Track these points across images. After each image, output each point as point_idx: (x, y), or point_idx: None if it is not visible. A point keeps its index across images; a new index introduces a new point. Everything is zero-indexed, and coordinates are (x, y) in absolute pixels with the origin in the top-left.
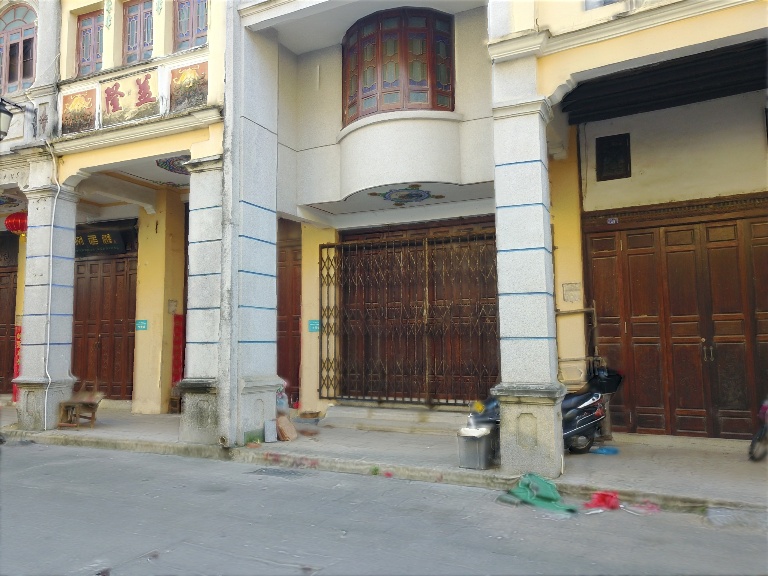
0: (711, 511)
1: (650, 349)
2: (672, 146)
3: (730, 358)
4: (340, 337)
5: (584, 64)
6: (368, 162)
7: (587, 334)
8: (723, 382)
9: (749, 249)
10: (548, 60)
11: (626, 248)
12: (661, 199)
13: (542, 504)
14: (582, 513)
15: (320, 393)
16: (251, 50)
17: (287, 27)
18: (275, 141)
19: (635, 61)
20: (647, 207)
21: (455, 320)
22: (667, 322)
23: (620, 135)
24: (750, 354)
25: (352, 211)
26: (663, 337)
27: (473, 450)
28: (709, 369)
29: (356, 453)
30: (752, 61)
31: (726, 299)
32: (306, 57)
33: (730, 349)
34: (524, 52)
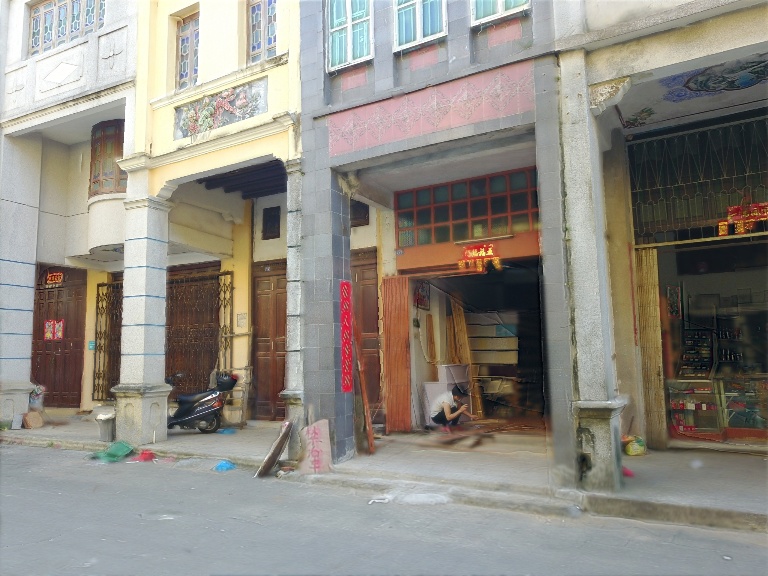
0: (190, 459)
1: None
2: None
3: None
4: (108, 354)
5: (171, 176)
6: (95, 229)
7: (249, 350)
8: None
9: None
10: (156, 171)
11: (276, 288)
12: None
13: (107, 459)
14: (120, 462)
15: (93, 396)
16: (11, 150)
17: (47, 130)
18: (36, 213)
19: (195, 175)
20: None
21: (175, 341)
22: None
23: (275, 207)
24: None
25: (110, 260)
26: None
27: (106, 429)
28: None
29: (59, 435)
30: None
31: None
32: (75, 147)
33: None
34: (138, 167)
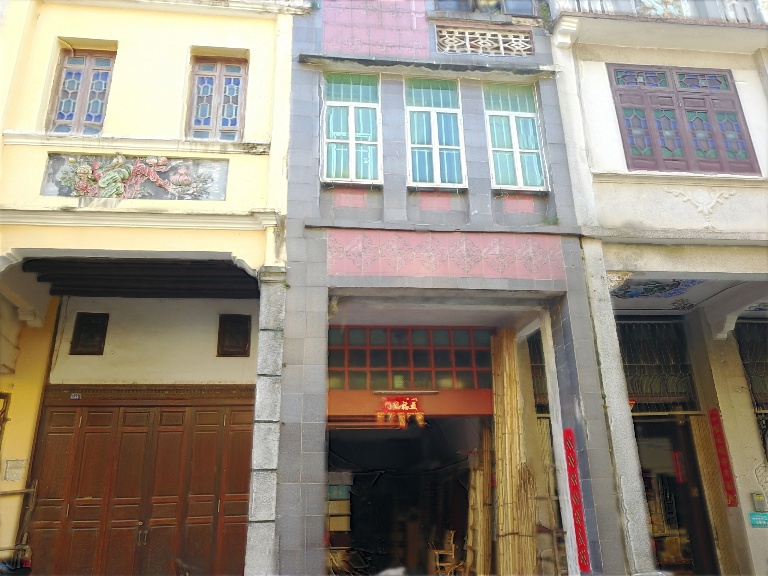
0: None
1: (88, 534)
2: (143, 332)
3: (161, 542)
4: None
5: (26, 242)
6: None
7: (23, 518)
8: (151, 567)
9: (192, 435)
10: None
11: (85, 425)
12: (125, 380)
13: None
14: None
15: None
16: None
17: None
18: None
19: (75, 251)
20: (111, 386)
21: None
22: (110, 505)
23: (100, 314)
24: (178, 537)
25: None
26: (103, 521)
27: None
28: (141, 554)
29: None
30: (199, 274)
31: (166, 482)
32: None
33: (163, 532)
34: None
